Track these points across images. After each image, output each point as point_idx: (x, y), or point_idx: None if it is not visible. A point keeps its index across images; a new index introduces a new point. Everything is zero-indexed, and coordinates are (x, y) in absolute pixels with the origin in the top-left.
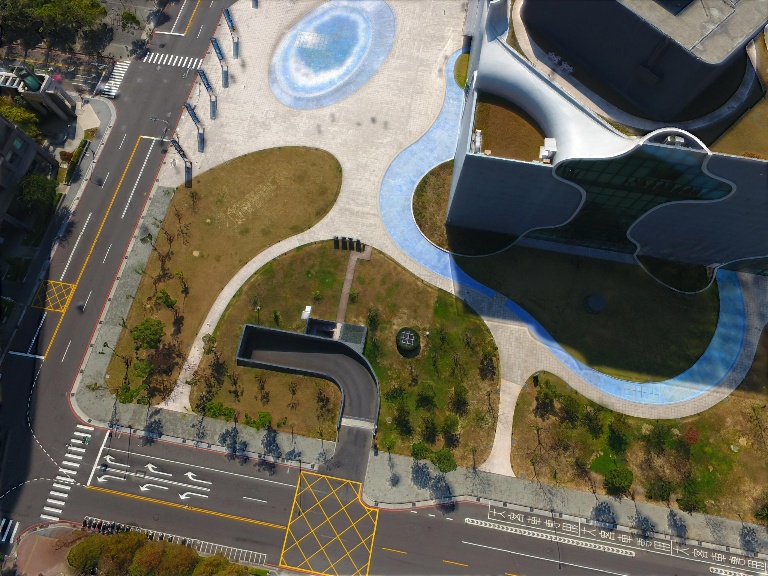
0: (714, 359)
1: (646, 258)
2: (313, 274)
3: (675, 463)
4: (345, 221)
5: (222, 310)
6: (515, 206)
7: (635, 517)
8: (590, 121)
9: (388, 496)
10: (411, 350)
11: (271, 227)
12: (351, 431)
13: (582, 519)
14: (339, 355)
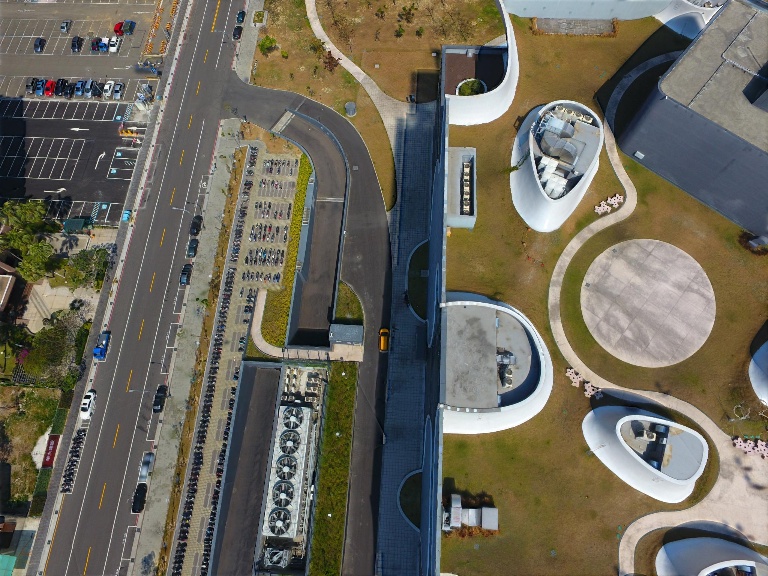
0: None
1: None
2: None
3: None
4: None
5: None
6: None
7: None
8: None
9: None
10: None
11: None
12: None
13: None
14: None
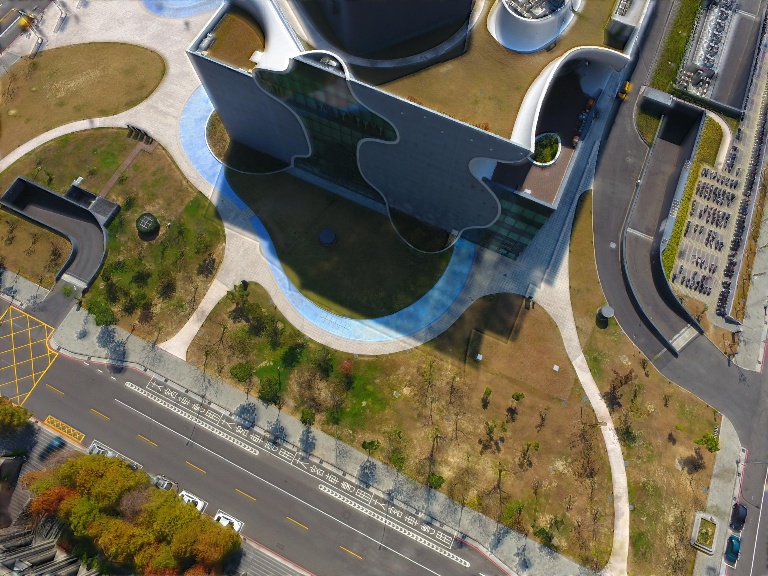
0: (416, 314)
1: (396, 211)
2: (98, 153)
3: (333, 390)
4: (146, 116)
5: (10, 163)
6: (262, 124)
7: (274, 423)
8: (289, 41)
9: (71, 345)
10: (145, 233)
11: (82, 106)
12: (66, 286)
13: (227, 411)
14: (90, 224)
